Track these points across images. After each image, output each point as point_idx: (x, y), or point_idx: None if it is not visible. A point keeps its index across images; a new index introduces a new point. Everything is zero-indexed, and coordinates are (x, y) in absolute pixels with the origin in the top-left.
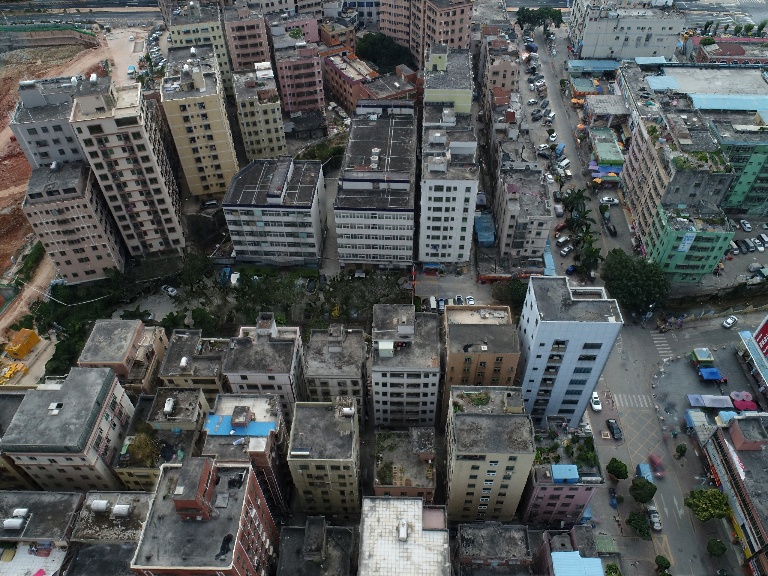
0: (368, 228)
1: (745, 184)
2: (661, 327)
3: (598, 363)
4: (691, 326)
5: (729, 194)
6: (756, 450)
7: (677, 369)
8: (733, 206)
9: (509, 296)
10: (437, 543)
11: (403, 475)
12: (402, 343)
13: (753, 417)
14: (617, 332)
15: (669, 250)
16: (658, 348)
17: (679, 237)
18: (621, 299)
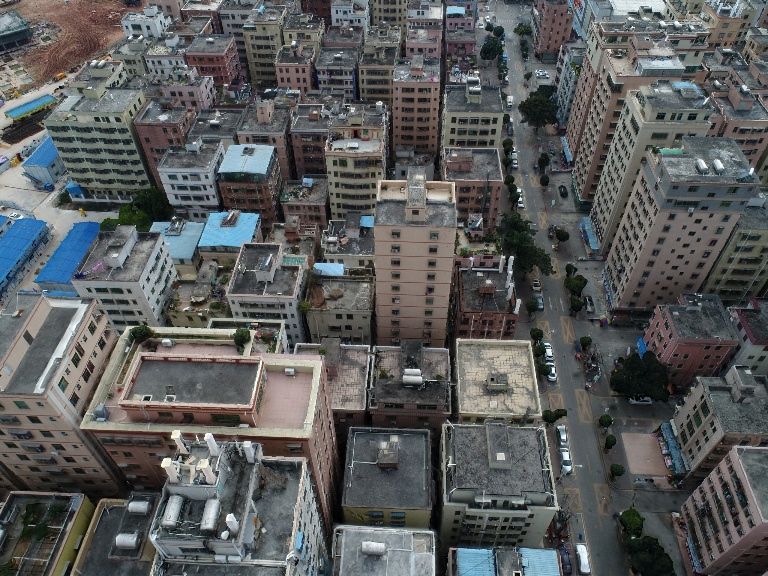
0: None
1: None
2: (529, 3)
3: None
4: None
5: None
6: None
7: None
8: None
9: None
10: None
11: None
12: None
13: None
14: None
15: None
16: (525, 9)
17: None
18: None
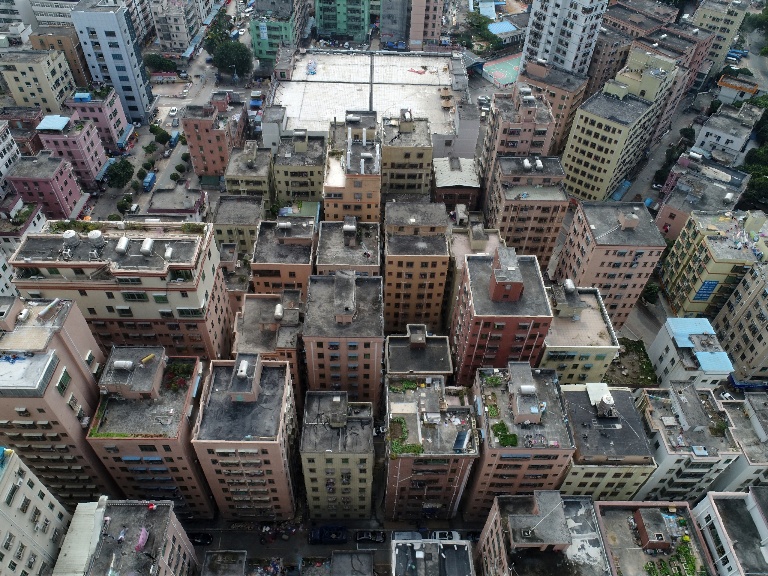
0: (57, 16)
1: (342, 14)
2: (246, 86)
3: (122, 50)
4: (267, 87)
5: (335, 22)
6: (224, 111)
7: None
8: (342, 33)
9: (146, 62)
10: None
11: (1, 106)
12: (16, 42)
13: (222, 92)
14: (117, 21)
15: (256, 38)
16: None
17: (257, 26)
18: (215, 63)
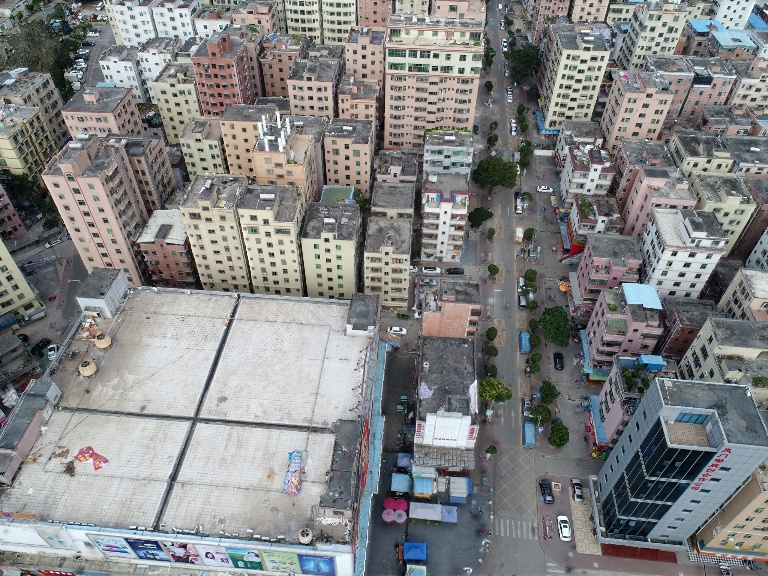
0: None
1: None
2: None
3: None
4: None
5: None
6: None
7: (448, 572)
8: None
9: None
10: (760, 293)
11: None
12: None
13: None
14: None
15: None
16: None
17: None
18: None
